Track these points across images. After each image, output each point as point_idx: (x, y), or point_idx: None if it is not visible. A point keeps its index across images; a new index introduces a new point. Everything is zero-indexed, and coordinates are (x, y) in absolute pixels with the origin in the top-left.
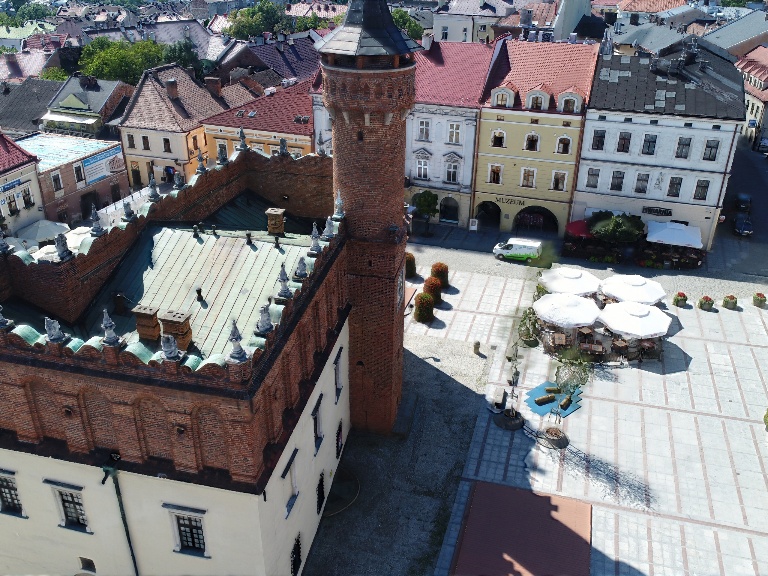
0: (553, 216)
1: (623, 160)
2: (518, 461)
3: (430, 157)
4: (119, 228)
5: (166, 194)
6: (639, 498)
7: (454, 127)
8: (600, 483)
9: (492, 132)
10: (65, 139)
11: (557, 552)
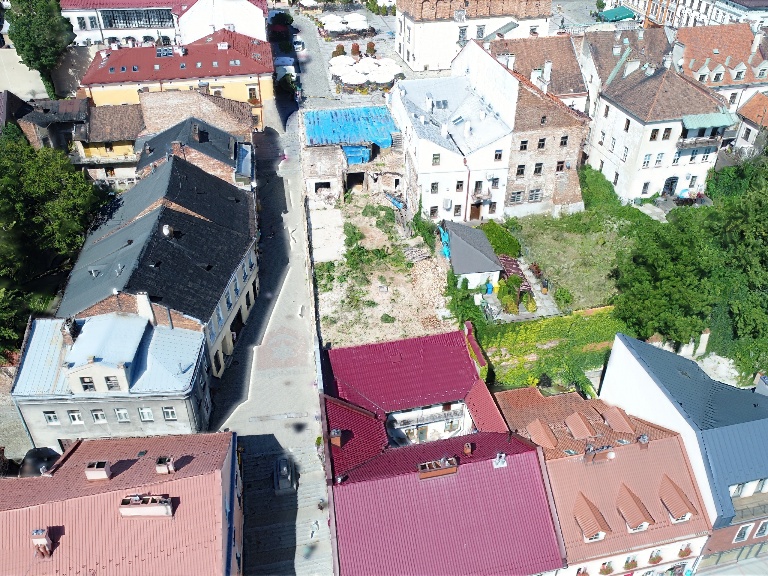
0: None
1: None
2: None
3: None
4: None
5: None
6: None
7: None
8: None
9: None
10: (311, 131)
11: None
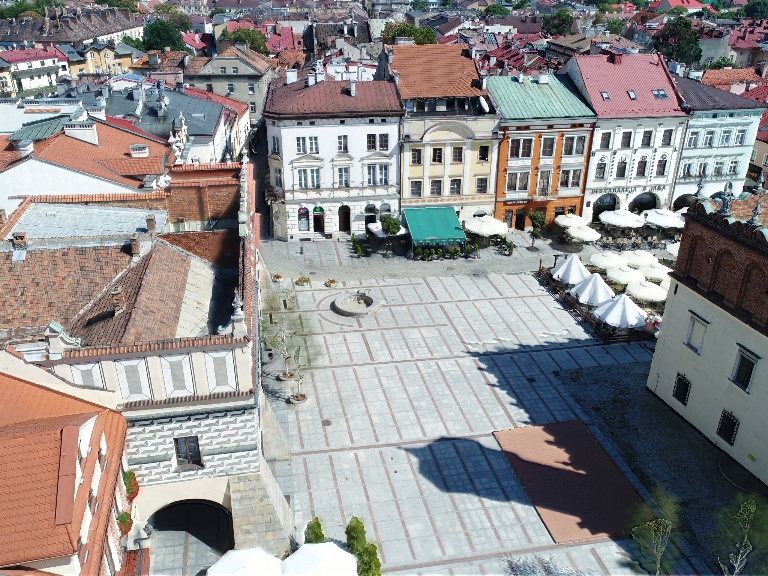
0: None
1: None
2: (653, 569)
3: None
4: None
5: None
6: (522, 568)
7: None
8: (564, 571)
9: None
10: None
11: (554, 489)
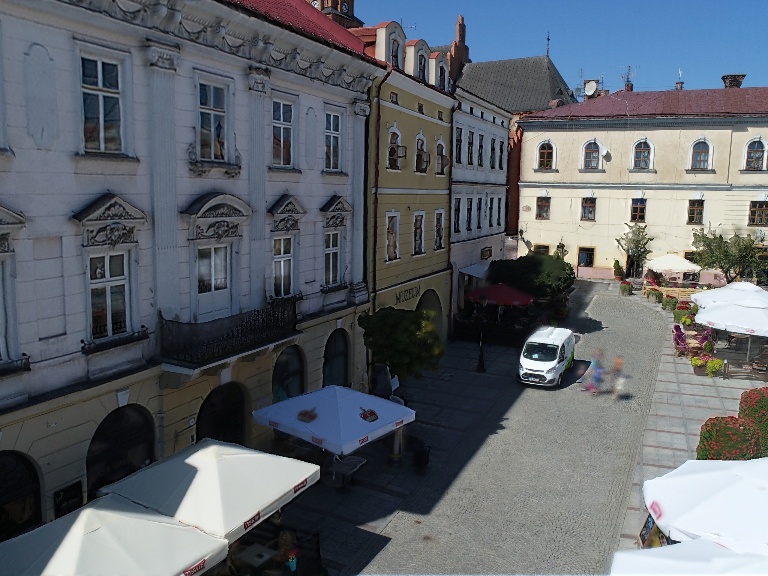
0: (438, 303)
1: (470, 178)
2: None
3: (298, 221)
4: None
5: None
6: None
7: (331, 123)
8: None
9: (389, 132)
10: None
11: None
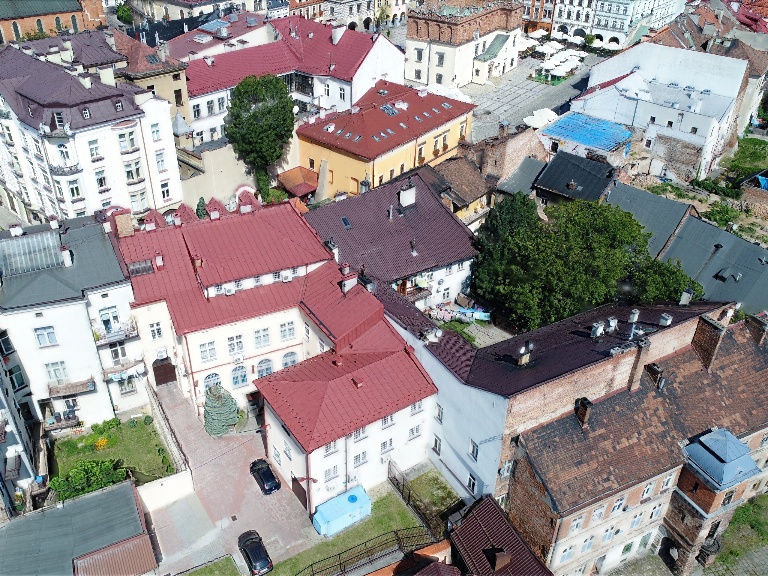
0: None
1: None
2: None
3: None
4: (491, 5)
5: (482, 8)
6: None
7: None
8: None
9: None
10: (581, 142)
11: None
